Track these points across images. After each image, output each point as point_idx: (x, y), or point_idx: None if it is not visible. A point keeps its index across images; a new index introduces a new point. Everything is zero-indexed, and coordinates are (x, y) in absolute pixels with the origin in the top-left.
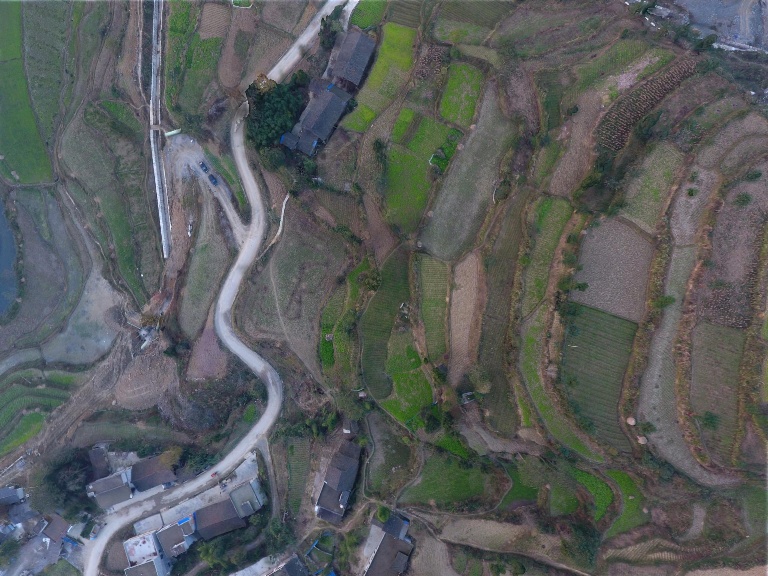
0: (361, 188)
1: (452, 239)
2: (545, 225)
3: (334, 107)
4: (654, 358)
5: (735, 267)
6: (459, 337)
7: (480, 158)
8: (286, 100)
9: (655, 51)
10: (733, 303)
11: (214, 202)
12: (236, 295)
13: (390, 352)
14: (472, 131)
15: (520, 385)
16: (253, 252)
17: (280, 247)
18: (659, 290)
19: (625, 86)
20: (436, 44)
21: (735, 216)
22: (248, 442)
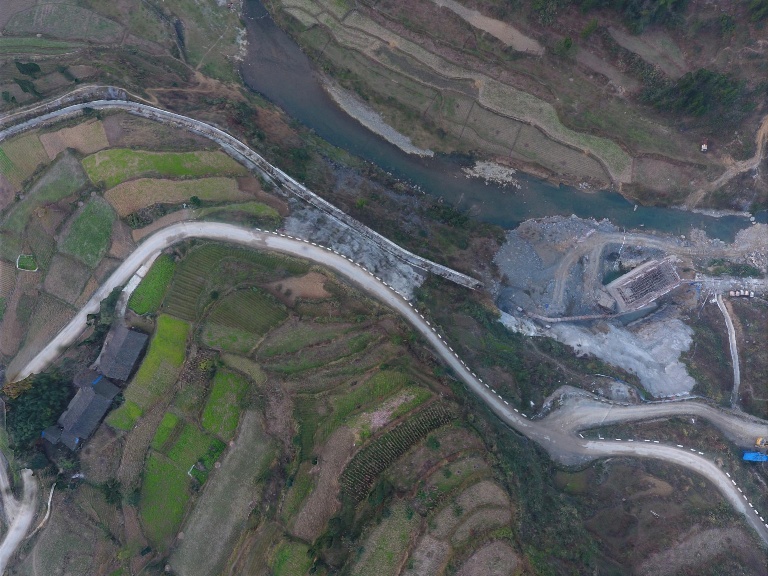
0: (120, 493)
1: (202, 563)
2: (284, 572)
3: (97, 406)
4: None
5: None
6: None
7: (237, 477)
8: (45, 398)
9: (411, 388)
10: None
11: None
12: (2, 575)
13: None
14: (231, 448)
15: None
16: (23, 530)
17: (45, 534)
18: None
19: (378, 424)
20: (204, 348)
21: None
22: None
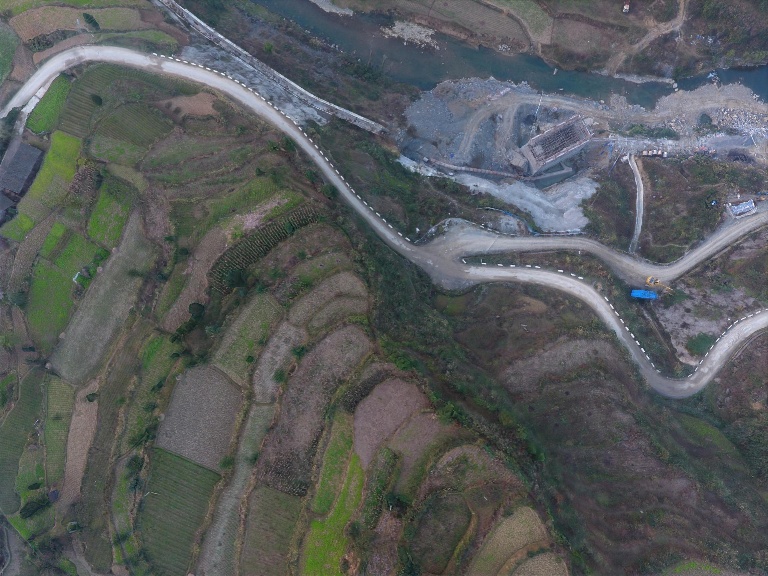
0: None
1: (82, 362)
2: (153, 363)
3: None
4: (220, 515)
5: (302, 432)
6: (74, 464)
7: (118, 282)
8: None
9: (285, 193)
10: (293, 470)
11: None
12: None
13: (20, 468)
14: (113, 254)
15: None
16: None
17: None
18: (233, 447)
19: (251, 226)
20: (92, 160)
21: (307, 381)
22: None
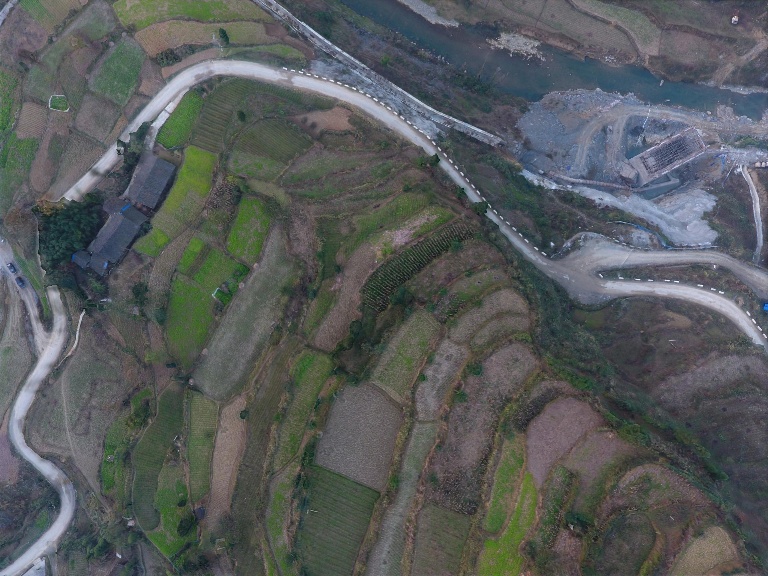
0: (146, 315)
1: (225, 379)
2: (305, 380)
3: (125, 230)
4: (384, 534)
5: (469, 451)
6: (220, 481)
7: (260, 298)
8: (76, 220)
9: (434, 209)
10: (462, 488)
11: (21, 304)
12: (32, 402)
13: (160, 485)
14: (255, 270)
15: (265, 540)
16: (52, 360)
17: (73, 361)
18: (397, 465)
19: (400, 243)
20: (230, 175)
21: (474, 399)
22: (38, 548)
